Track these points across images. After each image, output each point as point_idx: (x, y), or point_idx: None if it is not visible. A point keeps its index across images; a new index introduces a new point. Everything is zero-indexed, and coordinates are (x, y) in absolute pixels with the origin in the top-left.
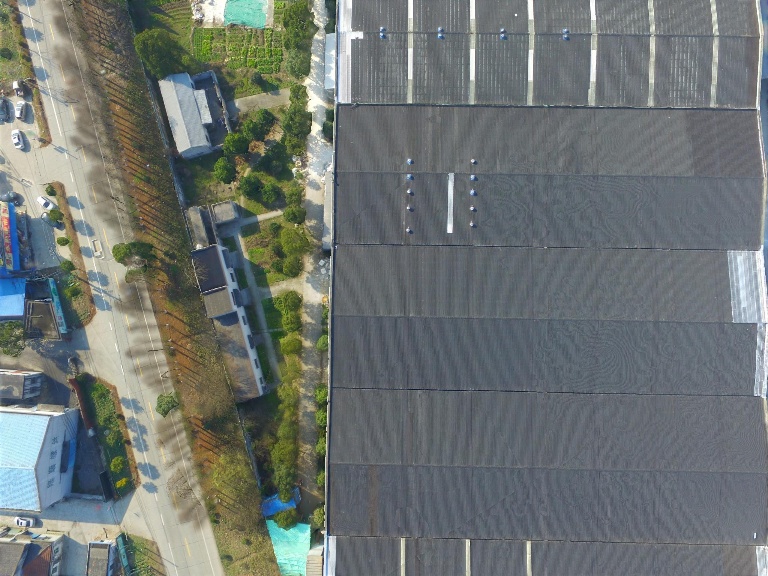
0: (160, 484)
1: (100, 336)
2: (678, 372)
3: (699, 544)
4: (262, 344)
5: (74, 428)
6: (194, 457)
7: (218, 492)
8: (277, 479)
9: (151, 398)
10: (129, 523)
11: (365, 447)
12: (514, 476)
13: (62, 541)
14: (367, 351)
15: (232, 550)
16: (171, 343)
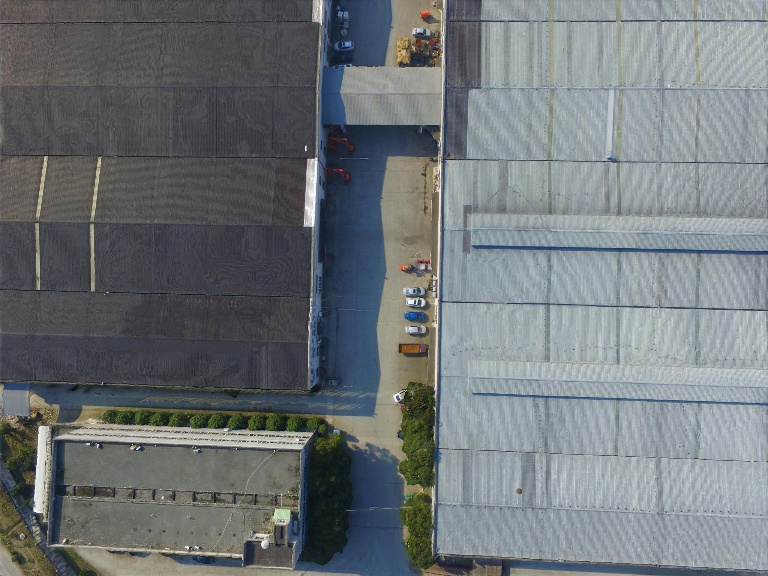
0: None
1: None
2: (244, 2)
3: (254, 157)
4: None
5: None
6: None
7: None
8: None
9: None
10: None
11: None
12: (84, 94)
13: None
14: None
15: None
16: None
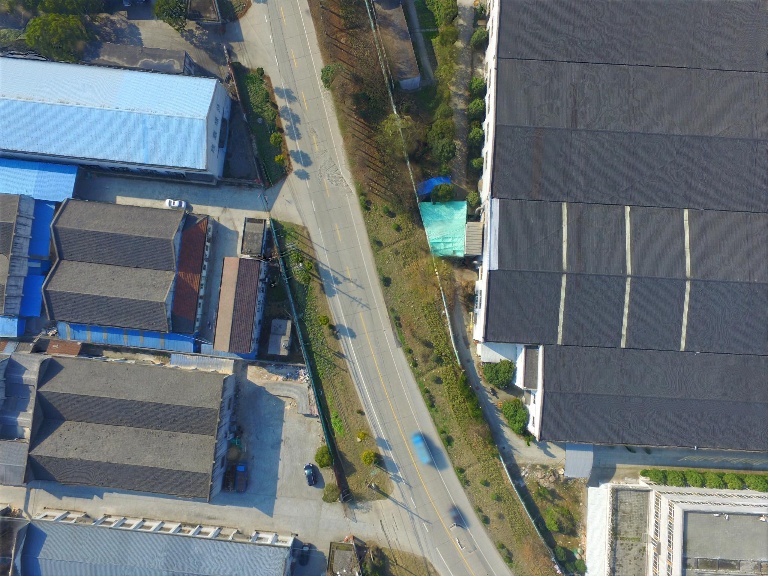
0: (312, 171)
1: (255, 28)
2: None
3: None
4: (414, 43)
5: (228, 114)
6: (346, 146)
7: (369, 180)
8: (440, 146)
9: (305, 88)
10: (279, 209)
11: (531, 111)
12: (675, 143)
13: (212, 224)
14: (534, 22)
15: (382, 236)
16: (326, 36)
